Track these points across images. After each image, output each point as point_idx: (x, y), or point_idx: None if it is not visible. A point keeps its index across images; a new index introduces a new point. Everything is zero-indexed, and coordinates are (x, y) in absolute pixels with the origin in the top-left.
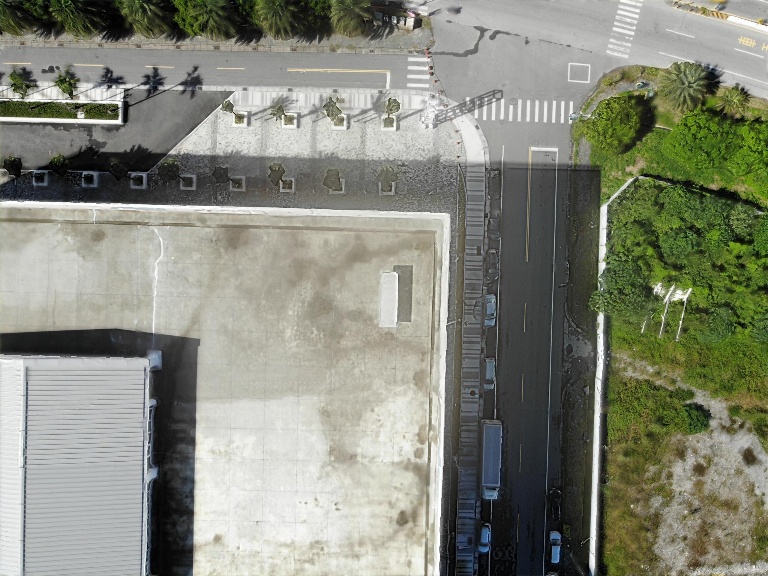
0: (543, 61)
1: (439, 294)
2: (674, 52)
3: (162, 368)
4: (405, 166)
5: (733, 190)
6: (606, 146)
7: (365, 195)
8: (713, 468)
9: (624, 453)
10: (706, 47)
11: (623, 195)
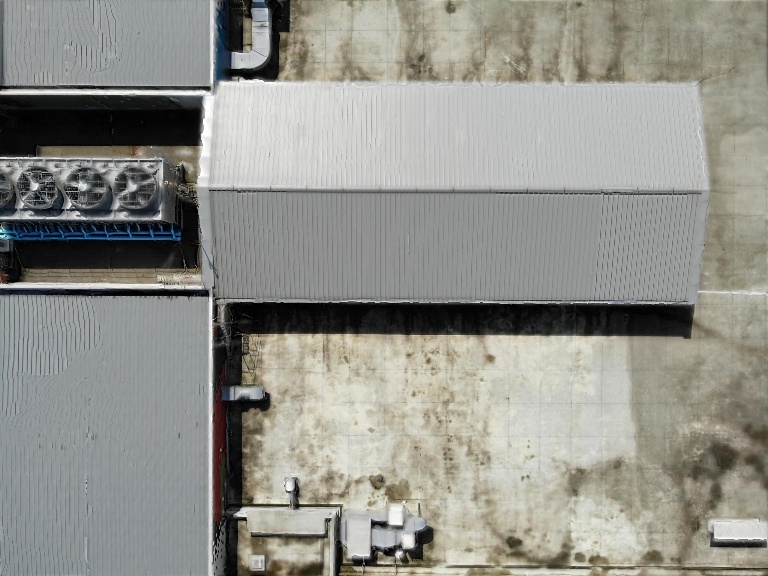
0: None
1: (739, 574)
2: None
3: None
4: None
5: None
6: None
7: None
8: None
9: None
10: None
11: None
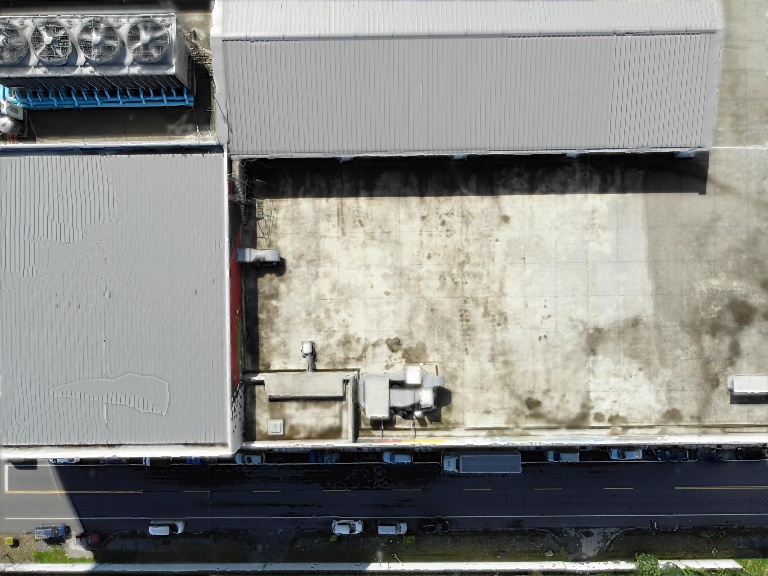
0: None
1: (760, 431)
2: None
3: (676, 158)
4: None
5: None
6: None
7: None
8: None
9: None
10: None
11: None
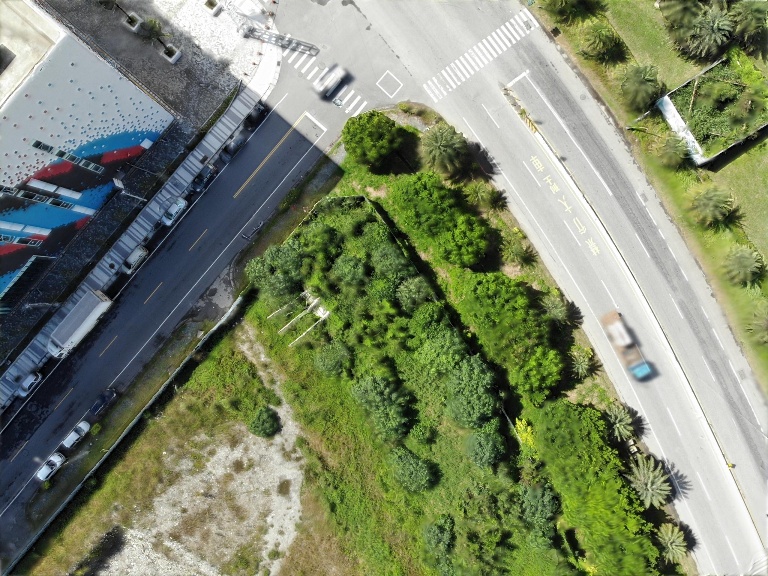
0: (369, 52)
1: None
2: (475, 126)
3: None
4: (199, 48)
5: (436, 270)
6: (350, 148)
7: (151, 46)
8: (250, 474)
9: (189, 405)
10: (502, 142)
11: (341, 201)
